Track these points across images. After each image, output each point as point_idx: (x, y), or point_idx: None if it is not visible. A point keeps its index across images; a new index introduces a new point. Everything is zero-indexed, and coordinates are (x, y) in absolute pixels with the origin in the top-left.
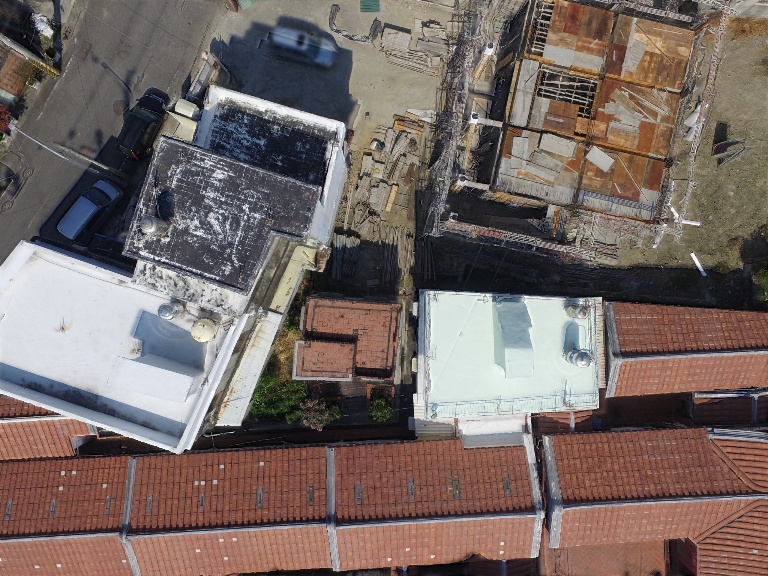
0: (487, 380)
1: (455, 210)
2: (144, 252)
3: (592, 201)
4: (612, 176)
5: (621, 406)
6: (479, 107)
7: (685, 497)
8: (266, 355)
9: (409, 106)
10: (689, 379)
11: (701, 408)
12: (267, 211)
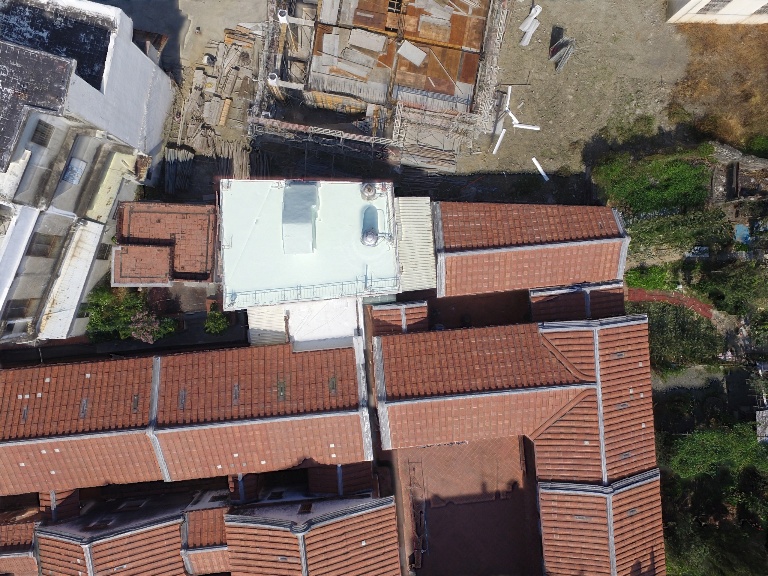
0: (286, 268)
1: (289, 121)
2: None
3: (406, 96)
4: (426, 70)
5: (468, 314)
6: (309, 17)
7: (511, 389)
8: (88, 266)
9: (240, 20)
10: (519, 275)
11: (537, 307)
12: (20, 86)
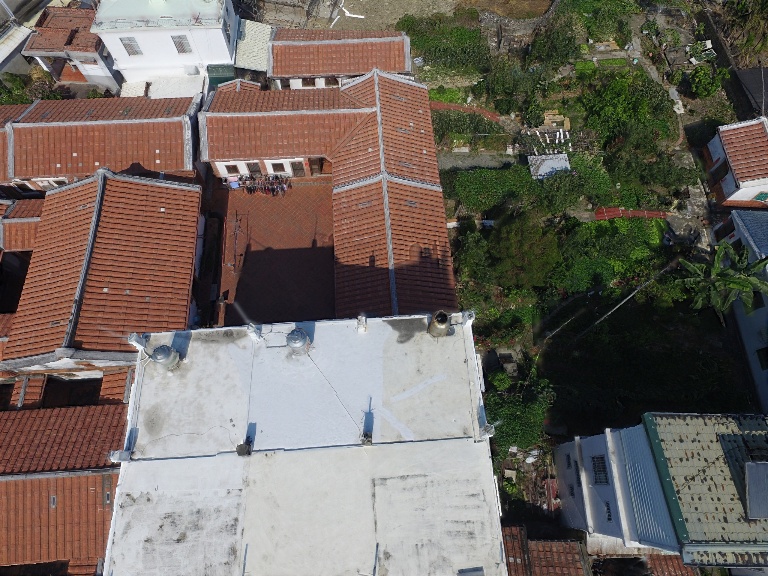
0: (142, 11)
1: None
2: None
3: None
4: None
5: None
6: None
7: None
8: (11, 50)
9: None
10: (329, 62)
11: None
12: None
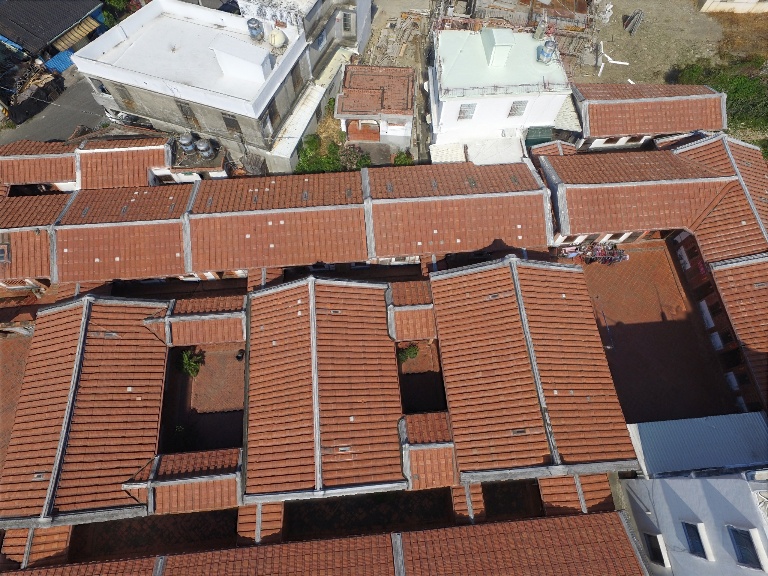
0: (484, 76)
1: None
2: None
3: (542, 19)
4: (553, 7)
5: None
6: (458, 5)
7: None
8: (313, 112)
9: (411, 8)
10: (646, 121)
11: (664, 149)
12: None
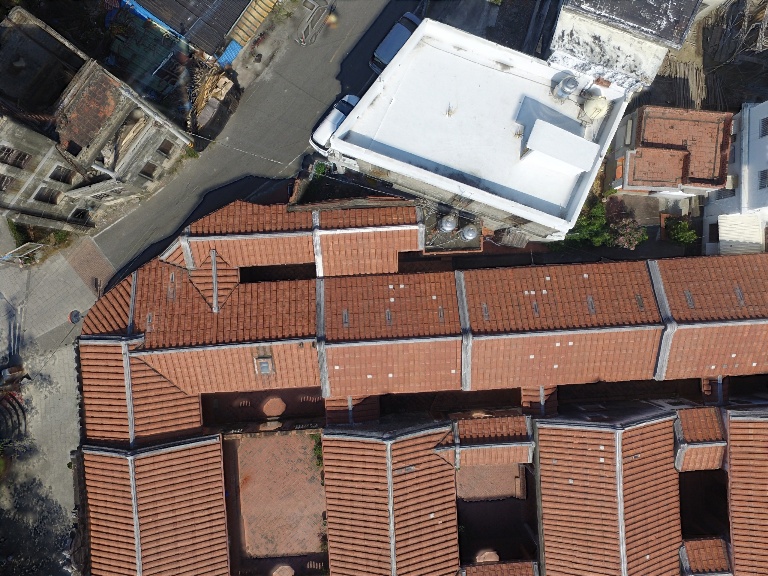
0: None
1: None
2: (585, 6)
3: None
4: None
5: None
6: None
7: None
8: None
9: None
10: None
11: None
12: None
